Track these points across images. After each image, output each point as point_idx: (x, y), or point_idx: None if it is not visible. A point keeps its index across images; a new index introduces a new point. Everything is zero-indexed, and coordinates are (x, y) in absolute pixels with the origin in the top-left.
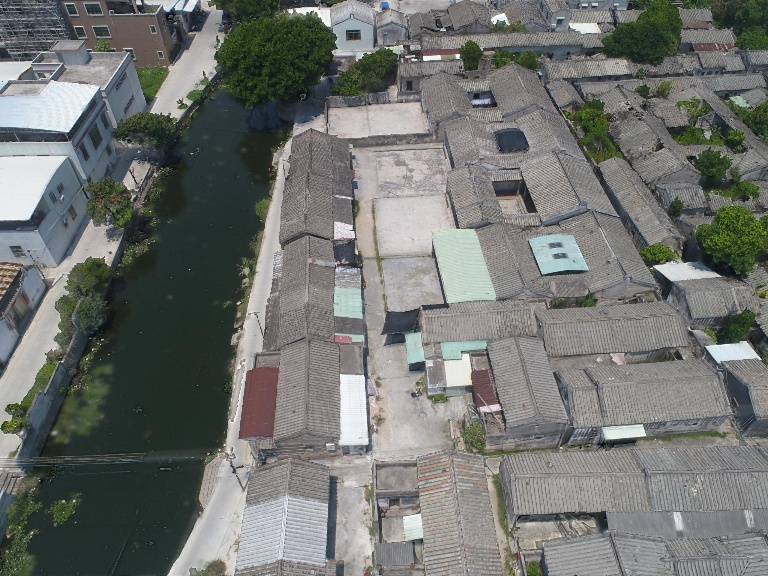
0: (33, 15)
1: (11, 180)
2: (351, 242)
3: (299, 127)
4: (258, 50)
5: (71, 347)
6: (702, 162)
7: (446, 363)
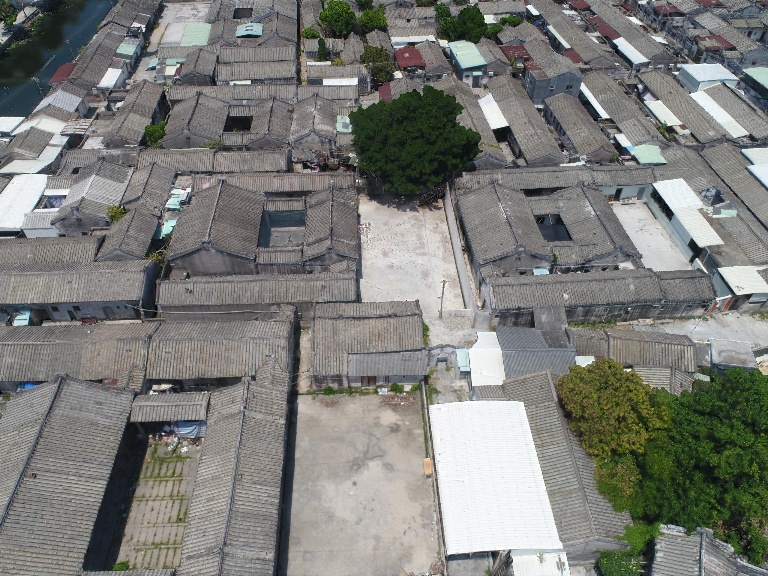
0: None
1: None
2: None
3: None
4: None
5: None
6: None
7: (167, 67)
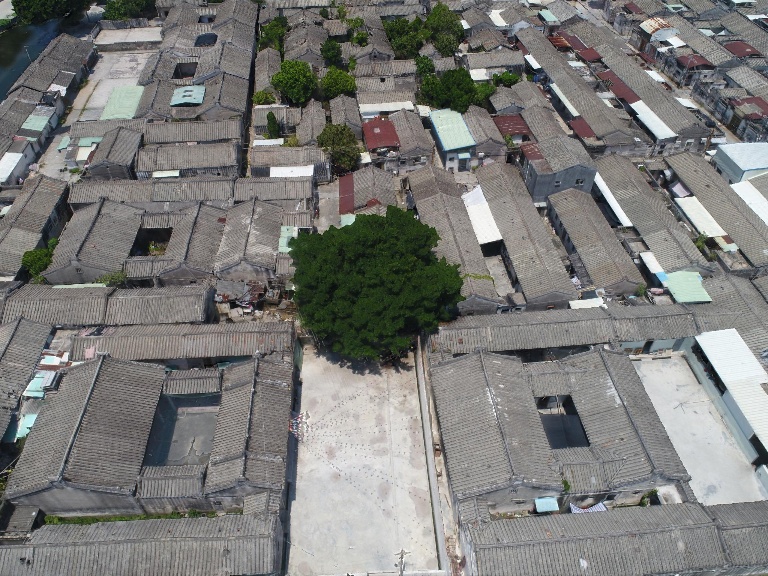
0: None
1: None
2: (56, 93)
3: None
4: None
5: None
6: (323, 49)
7: (80, 149)
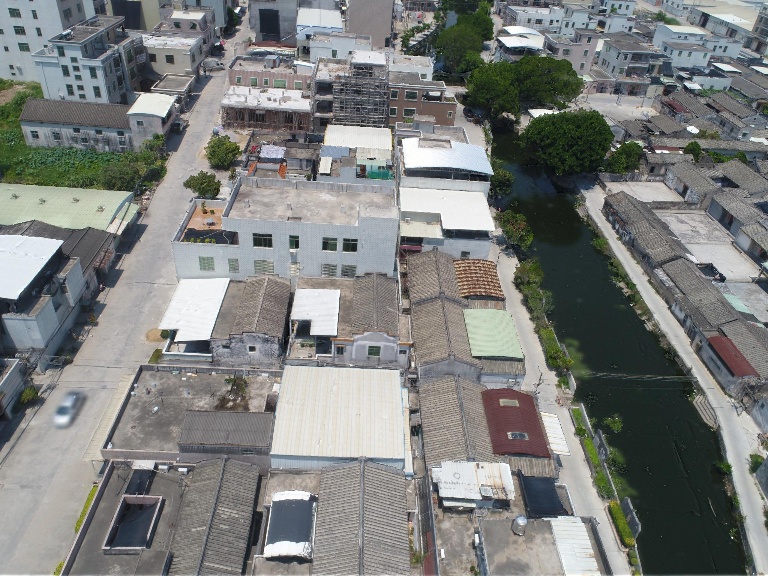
0: (367, 96)
1: (460, 204)
2: (708, 266)
3: (586, 192)
4: (574, 133)
5: (547, 321)
6: None
7: None
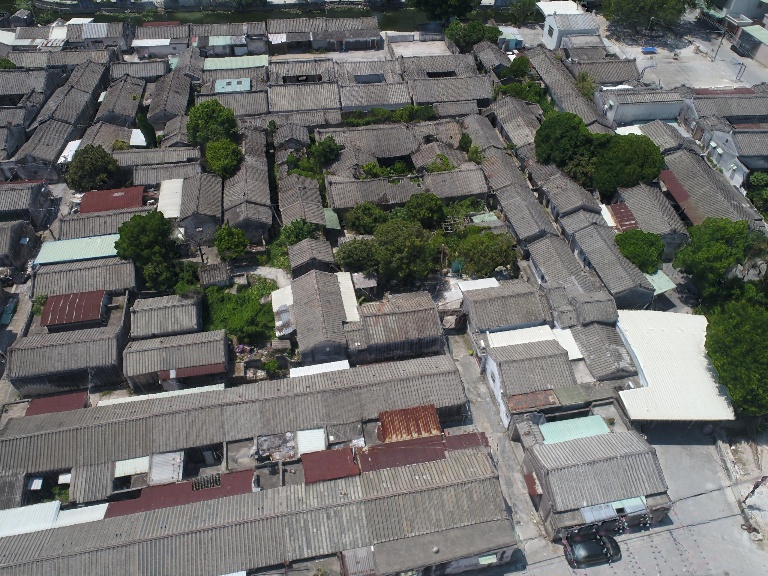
0: None
1: None
2: None
3: (414, 33)
4: None
5: (220, 1)
6: None
7: None
